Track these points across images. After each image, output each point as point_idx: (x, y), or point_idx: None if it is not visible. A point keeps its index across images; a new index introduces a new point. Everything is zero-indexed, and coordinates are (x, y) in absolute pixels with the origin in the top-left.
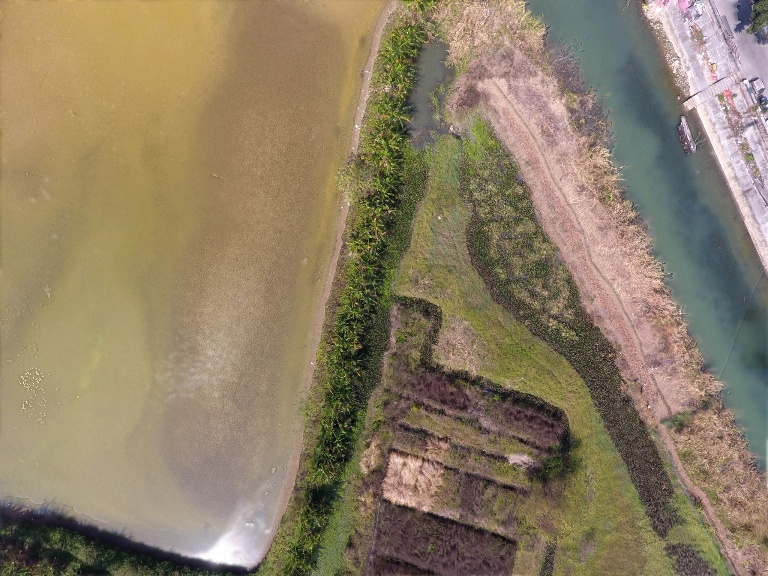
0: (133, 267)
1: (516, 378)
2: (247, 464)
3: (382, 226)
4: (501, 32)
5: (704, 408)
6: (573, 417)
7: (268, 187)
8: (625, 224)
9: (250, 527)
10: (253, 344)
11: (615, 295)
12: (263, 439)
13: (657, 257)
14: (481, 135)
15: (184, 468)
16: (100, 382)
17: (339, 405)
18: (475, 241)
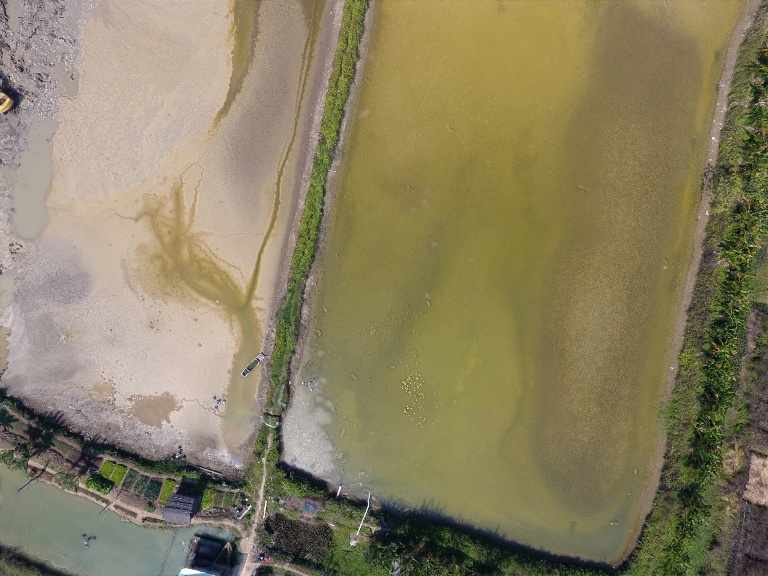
0: (505, 276)
1: None
2: (611, 465)
3: None
4: None
5: None
6: None
7: (630, 198)
8: None
9: (615, 526)
10: (616, 350)
11: None
12: (626, 441)
13: None
14: None
15: (553, 469)
16: (475, 387)
17: (723, 408)
18: None
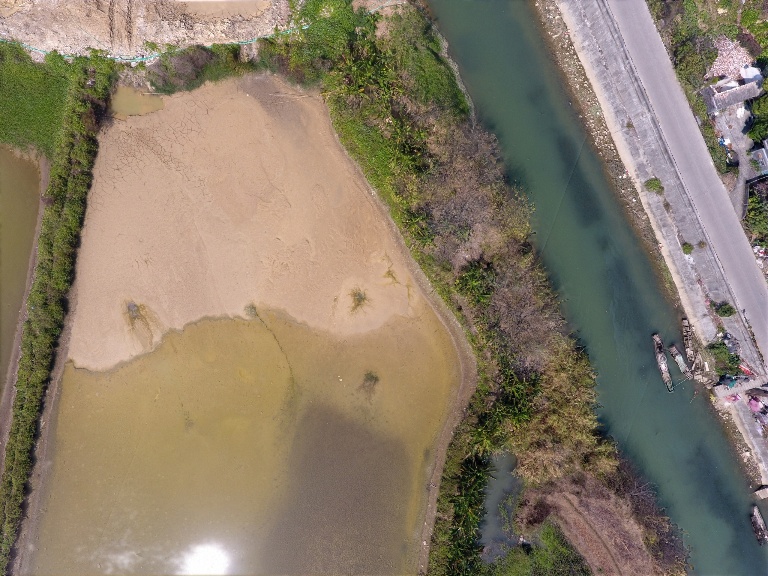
0: None
1: None
2: None
3: None
4: (572, 458)
5: None
6: None
7: None
8: None
9: None
10: None
11: None
12: None
13: None
14: (551, 542)
15: None
16: None
17: None
18: None
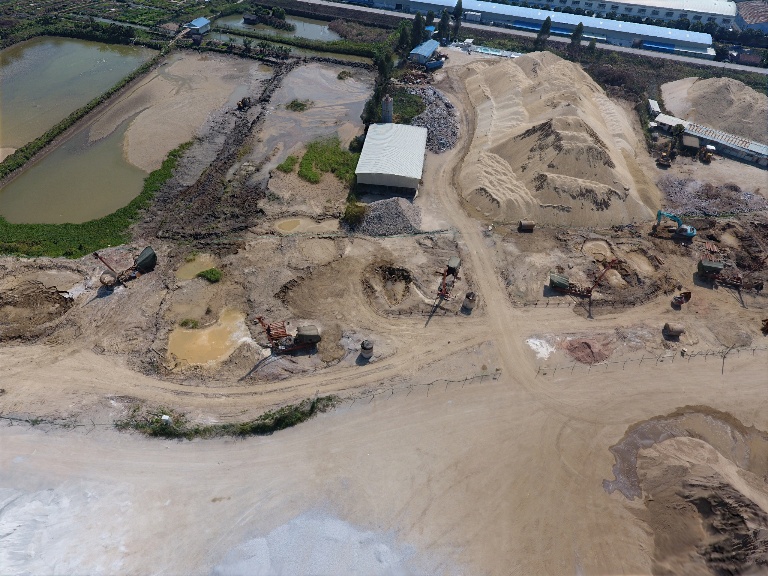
0: None
1: None
2: None
3: None
4: None
5: None
6: None
7: None
8: None
9: (40, 40)
10: None
11: None
12: None
13: None
14: None
15: None
16: None
17: None
18: None
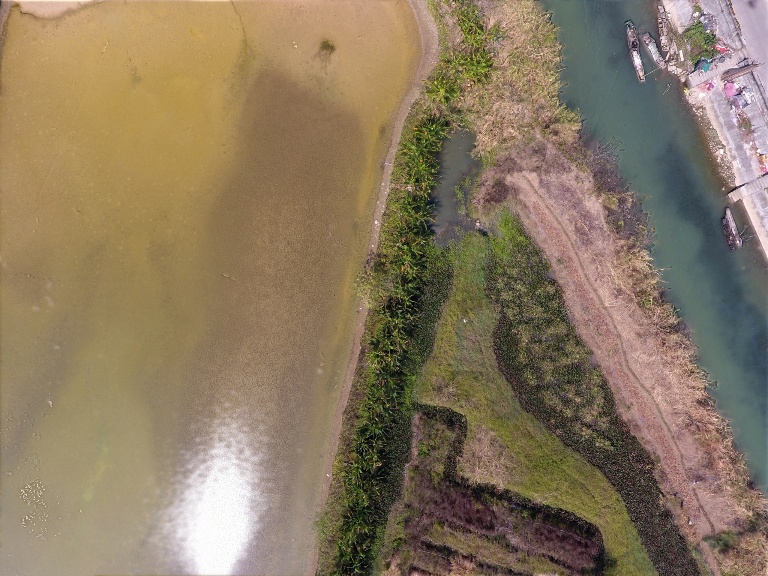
0: (139, 373)
1: (546, 492)
2: None
3: (404, 336)
4: (533, 125)
5: (751, 529)
6: (608, 534)
7: (282, 287)
8: (666, 331)
9: None
10: (265, 455)
11: (654, 404)
12: (276, 556)
13: (699, 360)
14: (509, 230)
15: None
16: (104, 495)
17: (357, 529)
18: (503, 345)
